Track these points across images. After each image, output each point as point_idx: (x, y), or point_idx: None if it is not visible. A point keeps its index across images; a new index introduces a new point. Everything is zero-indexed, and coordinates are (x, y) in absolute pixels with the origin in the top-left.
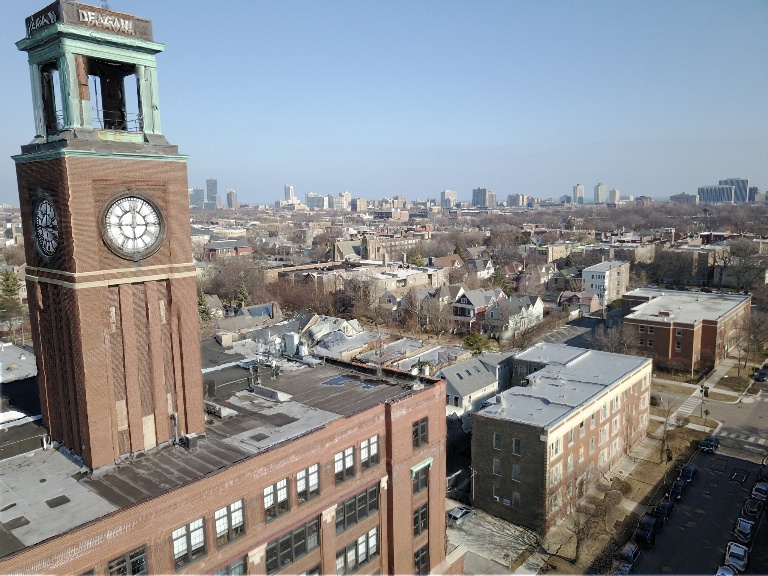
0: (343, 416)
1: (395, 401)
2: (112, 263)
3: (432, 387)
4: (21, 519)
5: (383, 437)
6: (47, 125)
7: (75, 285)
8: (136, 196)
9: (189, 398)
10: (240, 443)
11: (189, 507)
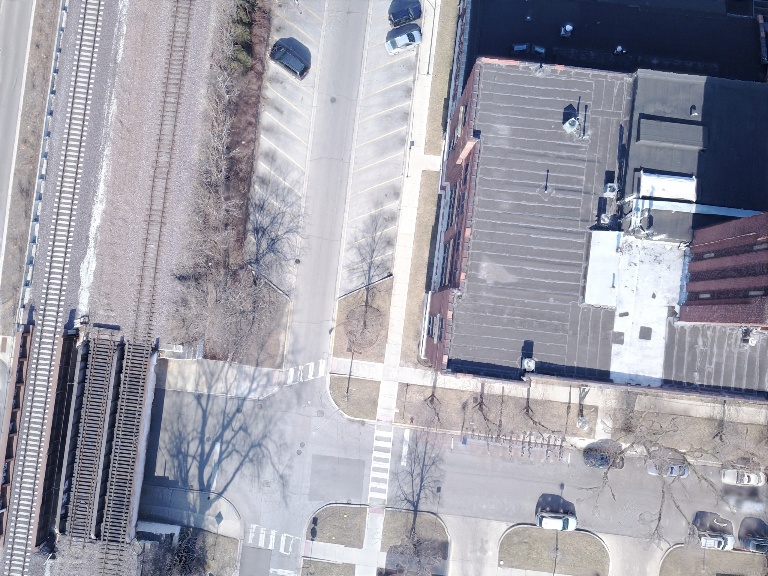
0: None
1: None
2: None
3: None
4: (622, 336)
5: None
6: None
7: None
8: None
9: None
10: None
11: None
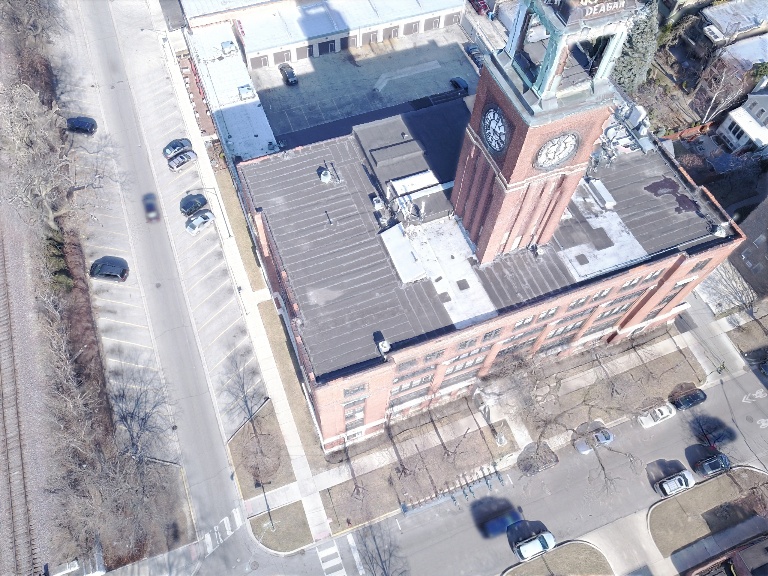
0: (645, 264)
1: (691, 257)
2: (532, 174)
3: (730, 244)
4: (447, 295)
5: (668, 268)
6: (517, 50)
7: (506, 191)
8: (567, 134)
9: (547, 229)
10: (569, 264)
11: (530, 313)
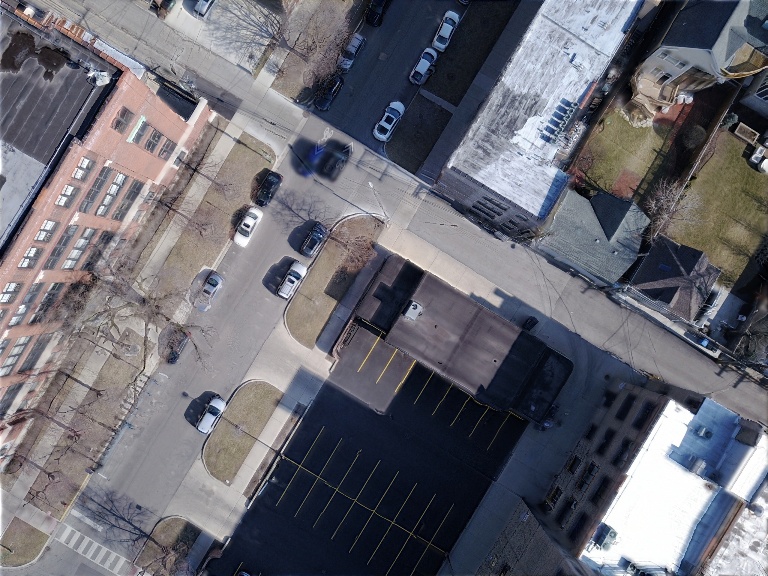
0: (44, 187)
1: (84, 141)
2: None
3: (115, 92)
4: None
5: (89, 151)
6: None
7: None
8: None
9: None
10: None
11: None
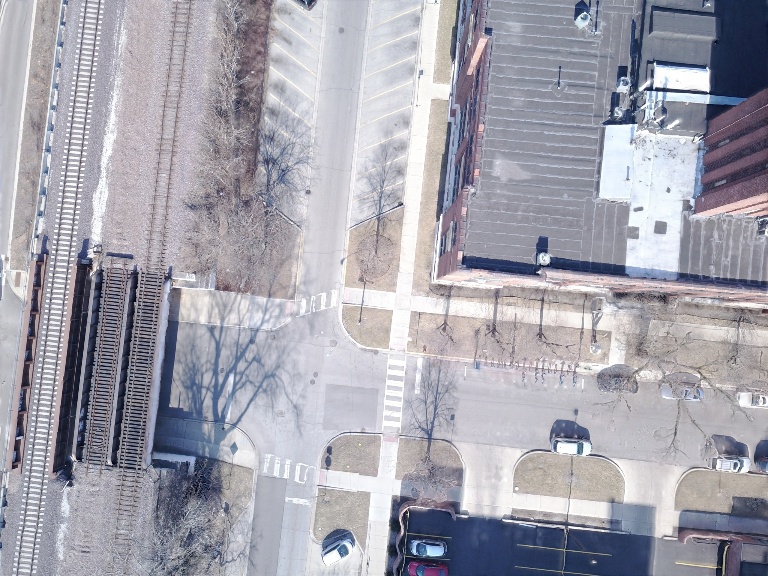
0: None
1: None
2: None
3: None
4: (637, 231)
5: None
6: None
7: None
8: None
9: None
10: None
11: None
